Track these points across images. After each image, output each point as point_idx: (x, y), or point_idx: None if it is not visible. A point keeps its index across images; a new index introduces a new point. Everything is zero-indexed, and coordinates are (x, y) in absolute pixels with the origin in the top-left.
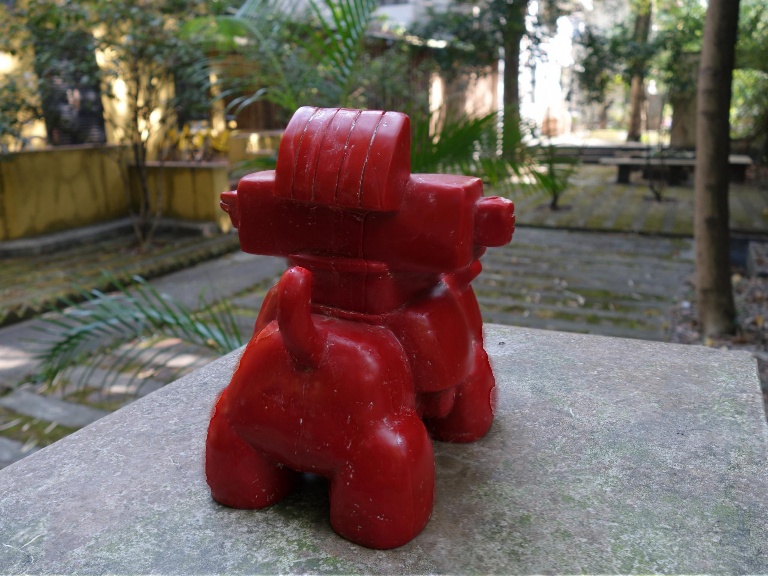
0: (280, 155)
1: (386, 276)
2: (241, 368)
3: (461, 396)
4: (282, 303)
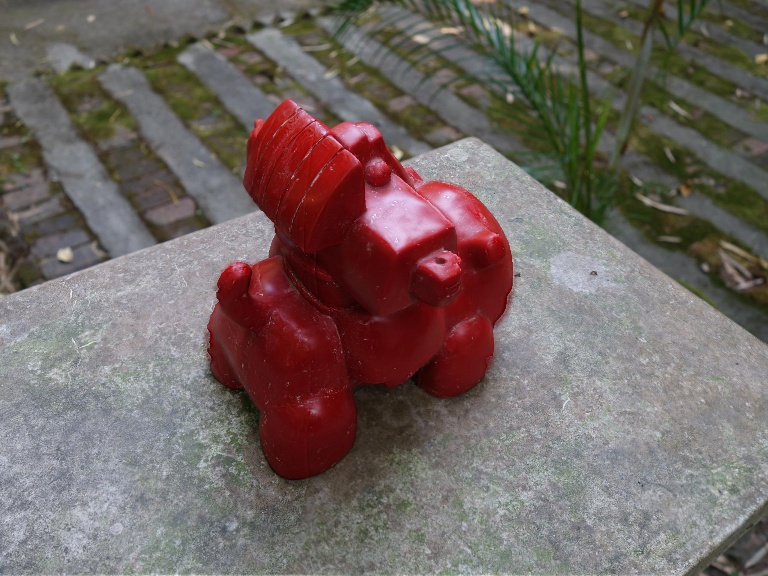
0: (252, 150)
1: (332, 284)
2: None
3: (436, 364)
4: (219, 291)
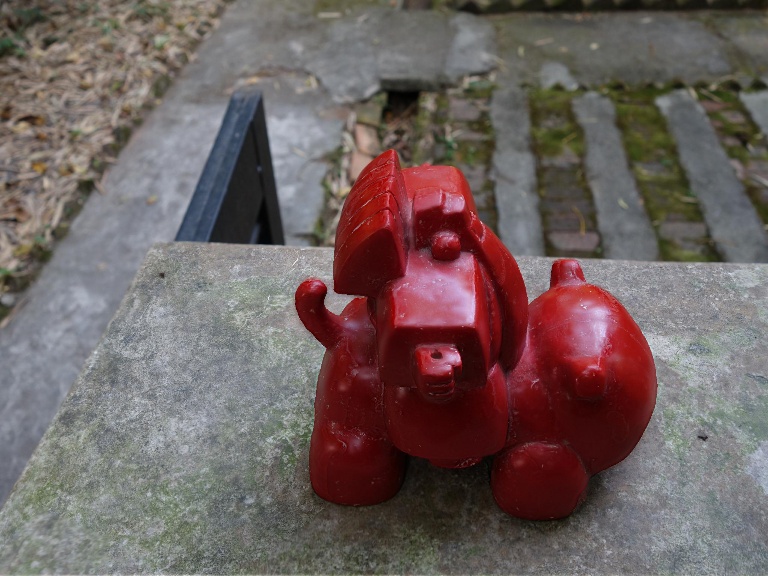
0: None
1: None
2: None
3: (500, 471)
4: None
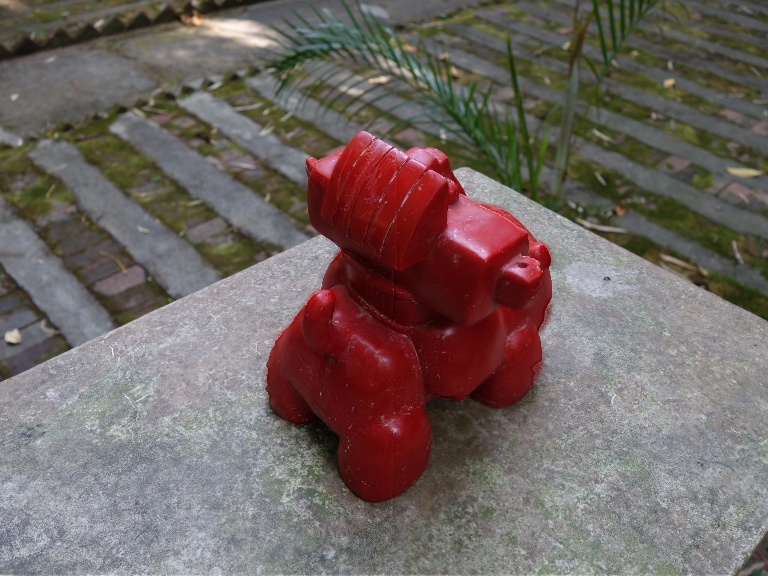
0: (330, 182)
1: (411, 302)
2: (292, 327)
3: (493, 374)
4: (305, 320)
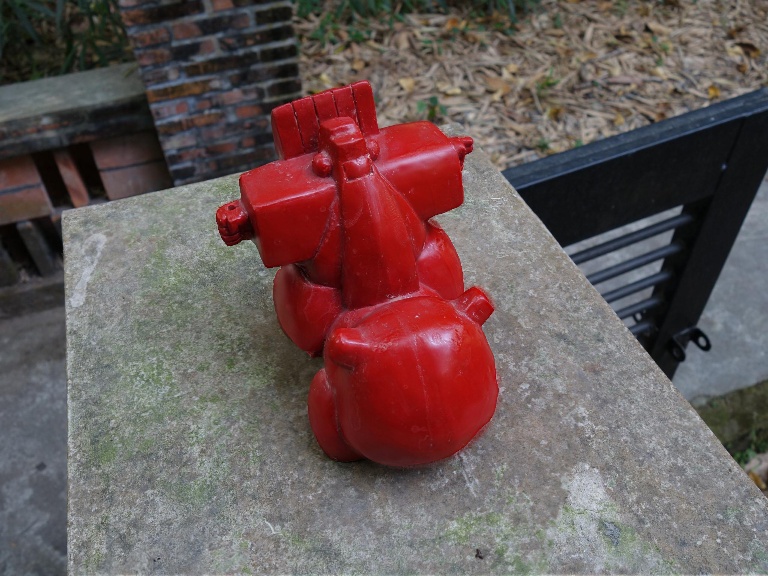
0: None
1: None
2: None
3: None
4: None
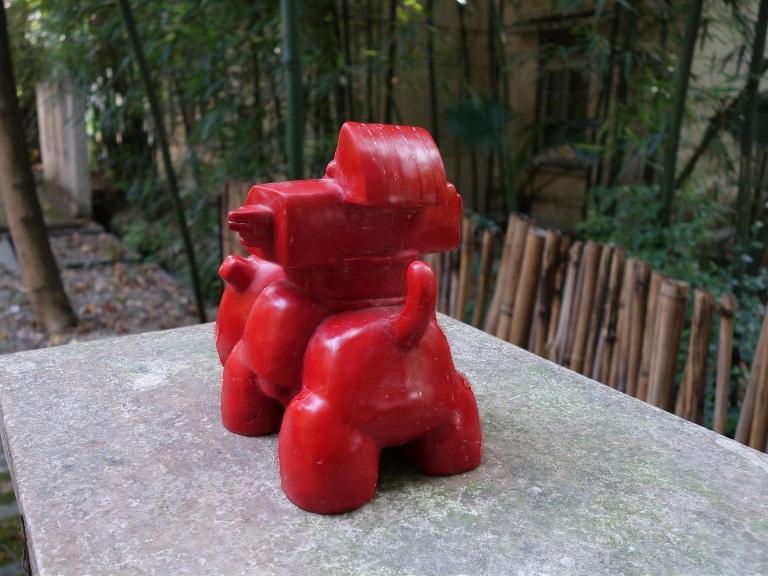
0: (365, 167)
1: None
2: (344, 374)
3: None
4: (427, 293)
